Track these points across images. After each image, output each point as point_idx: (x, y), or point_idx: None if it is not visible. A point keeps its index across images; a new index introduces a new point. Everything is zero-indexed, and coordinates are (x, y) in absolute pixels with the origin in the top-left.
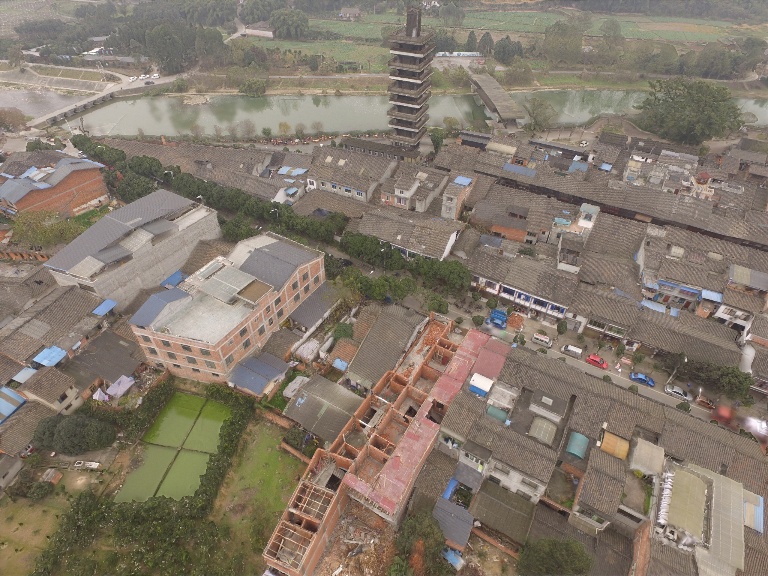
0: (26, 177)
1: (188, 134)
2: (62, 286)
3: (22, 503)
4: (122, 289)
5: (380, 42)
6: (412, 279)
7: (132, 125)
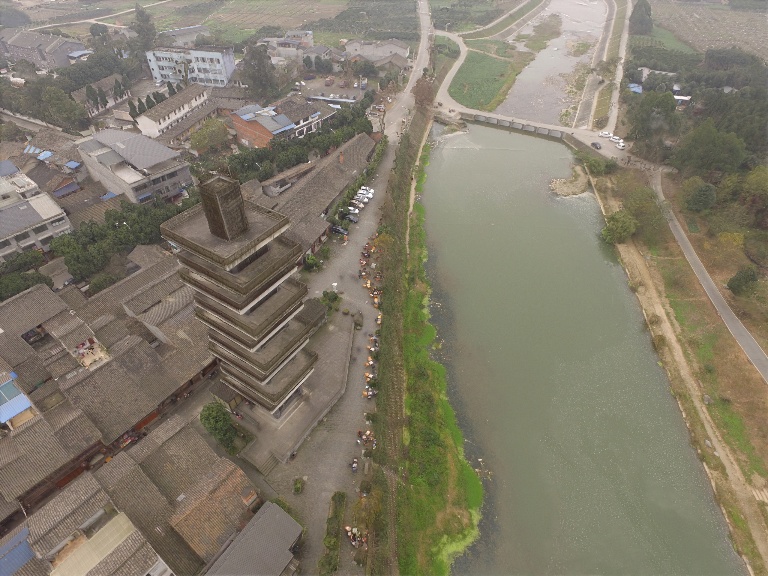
0: None
1: None
2: None
3: None
4: None
5: None
6: None
7: (475, 156)
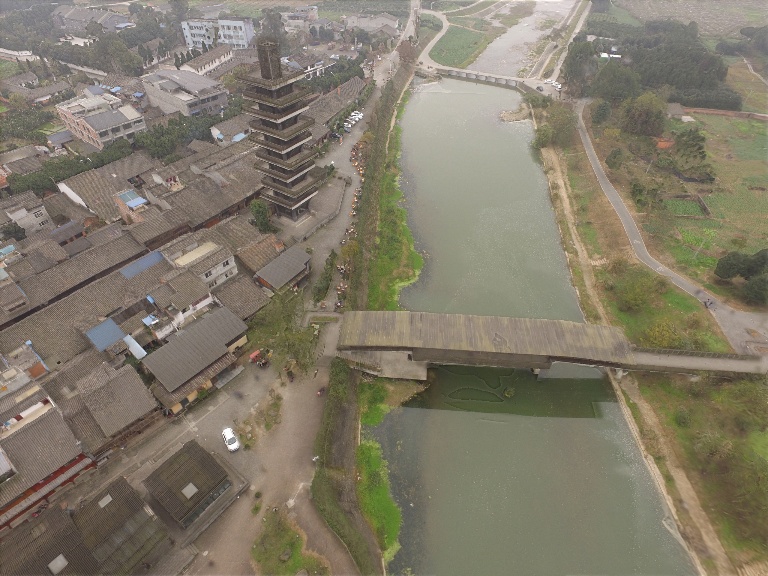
0: None
1: (382, 106)
2: None
3: None
4: None
5: None
6: None
7: (445, 98)
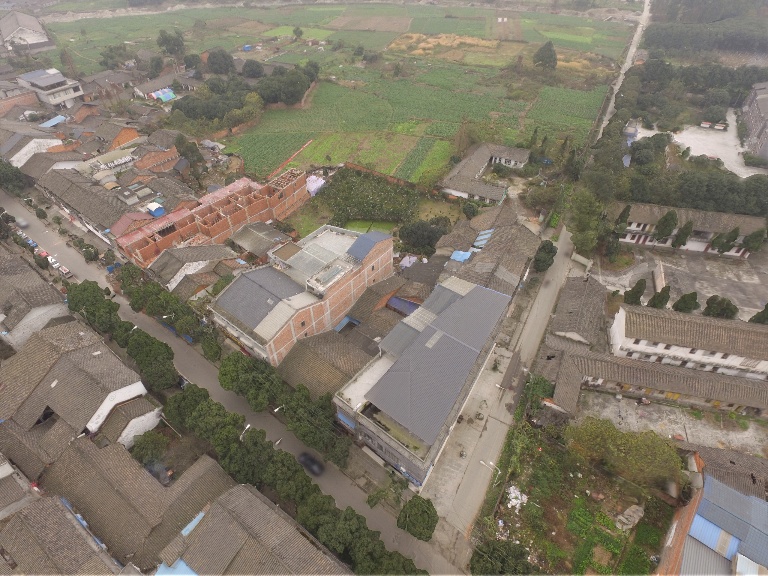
0: None
1: None
2: None
3: None
4: None
5: None
6: (119, 350)
7: None
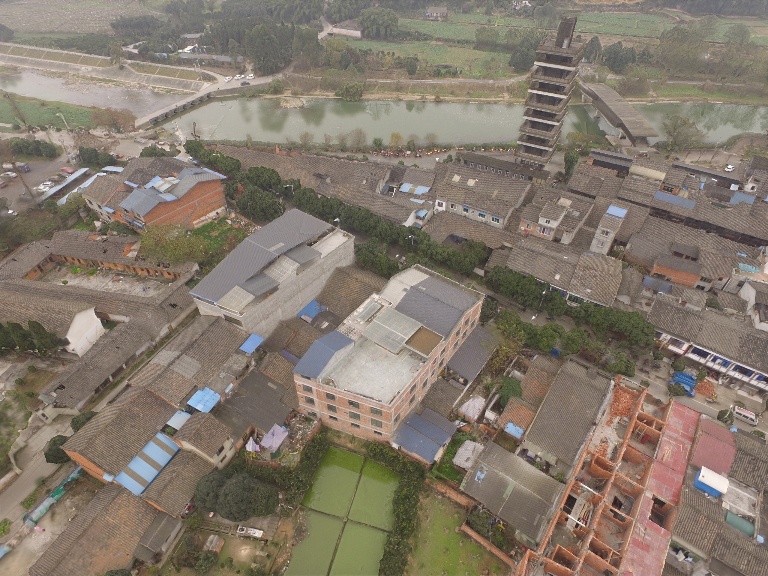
0: (151, 187)
1: (296, 142)
2: (204, 315)
3: (185, 573)
4: (264, 321)
5: (473, 44)
6: (569, 325)
7: (233, 128)
